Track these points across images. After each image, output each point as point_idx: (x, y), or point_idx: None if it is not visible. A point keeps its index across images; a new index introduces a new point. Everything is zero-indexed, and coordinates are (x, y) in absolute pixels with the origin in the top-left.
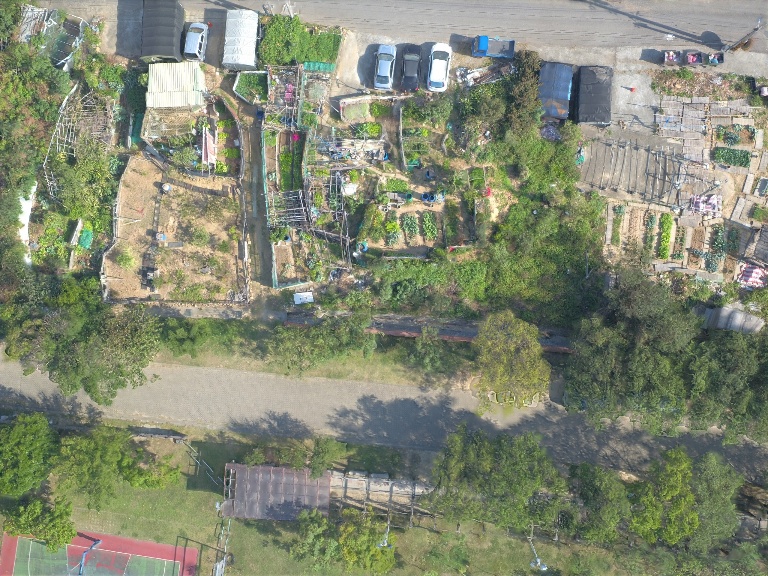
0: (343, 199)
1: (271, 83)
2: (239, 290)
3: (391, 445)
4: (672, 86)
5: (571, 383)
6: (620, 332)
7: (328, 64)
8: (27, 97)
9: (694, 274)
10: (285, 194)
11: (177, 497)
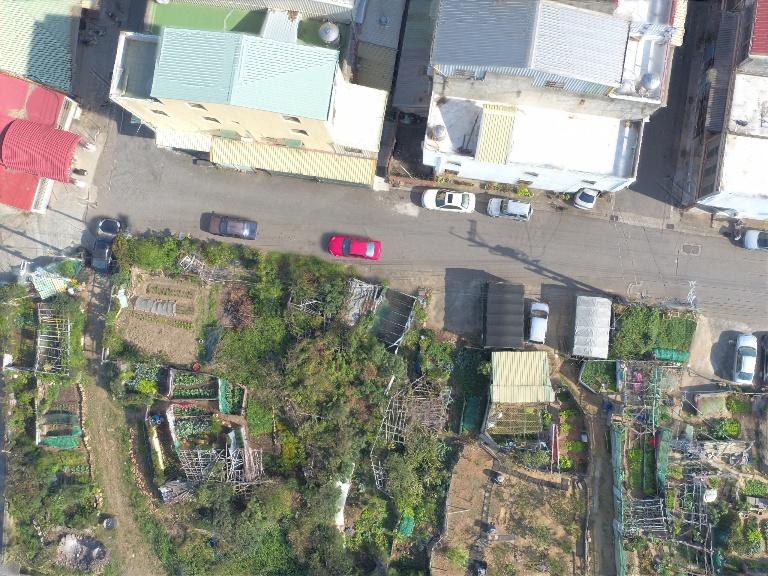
0: None
1: None
2: None
3: None
4: None
5: None
6: None
7: (681, 353)
8: (349, 376)
9: None
10: (645, 503)
11: None
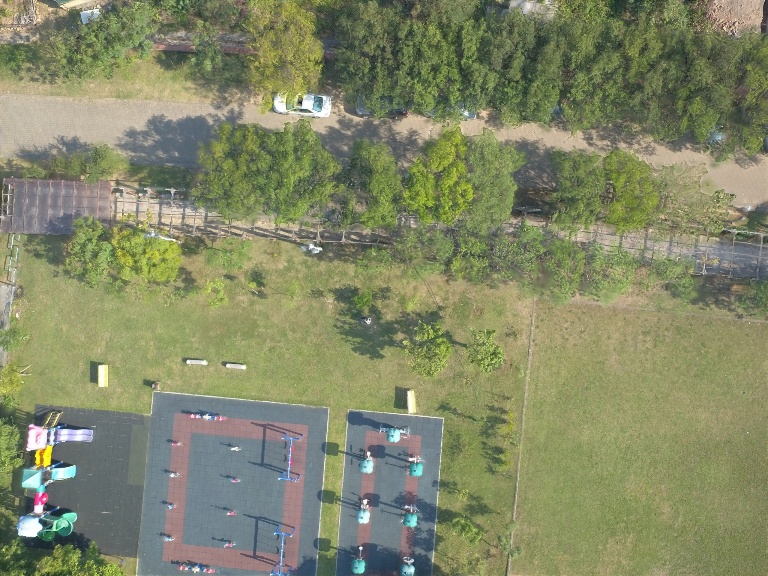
0: None
1: None
2: (25, 12)
3: (183, 165)
4: None
5: (346, 65)
6: (397, 13)
7: None
8: None
9: None
10: None
11: None
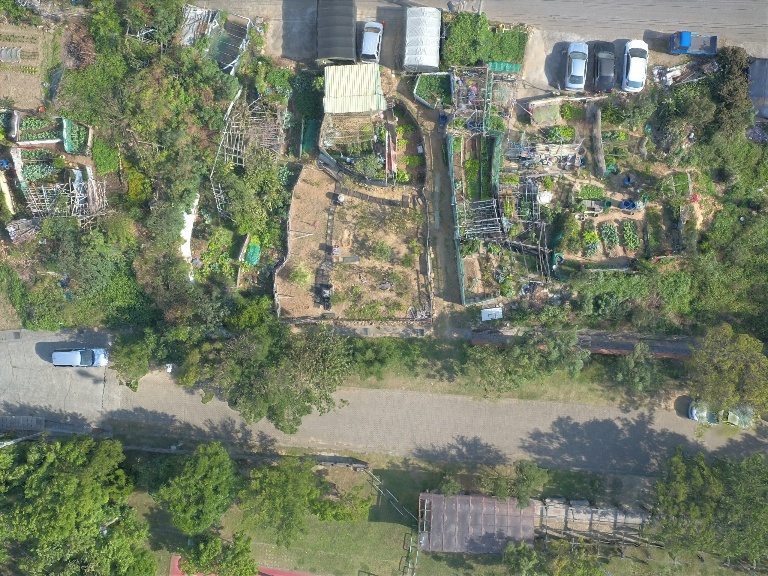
0: (539, 208)
1: None
2: (421, 307)
3: (590, 469)
4: None
5: None
6: None
7: (514, 64)
8: (189, 104)
9: None
10: (478, 204)
11: (358, 529)
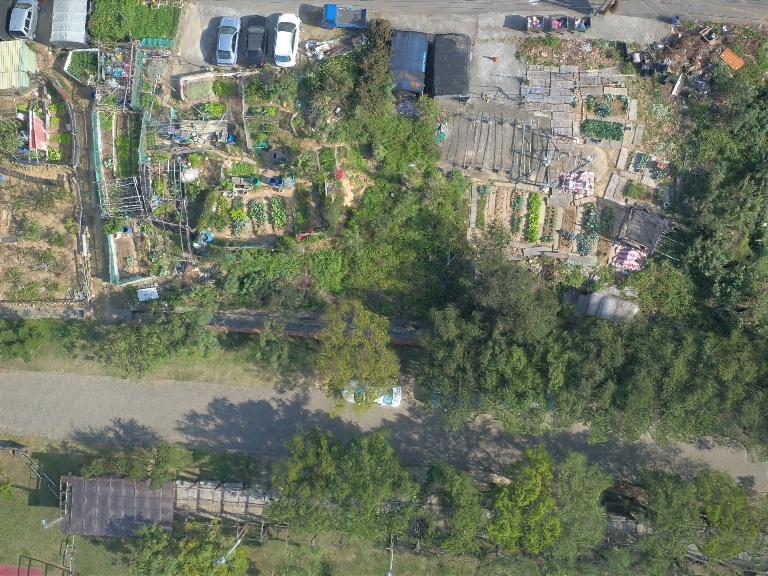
0: (183, 185)
1: (105, 62)
2: (79, 287)
3: (245, 451)
4: (538, 54)
5: (423, 380)
6: (476, 323)
7: (167, 40)
8: None
9: (565, 258)
10: (118, 181)
11: (18, 513)
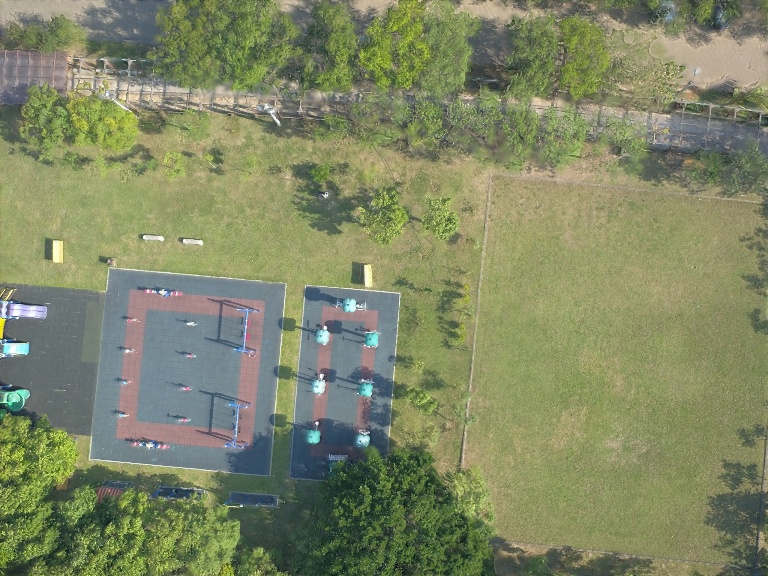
0: None
1: None
2: None
3: (141, 42)
4: None
5: None
6: None
7: None
8: None
9: None
10: None
11: None
